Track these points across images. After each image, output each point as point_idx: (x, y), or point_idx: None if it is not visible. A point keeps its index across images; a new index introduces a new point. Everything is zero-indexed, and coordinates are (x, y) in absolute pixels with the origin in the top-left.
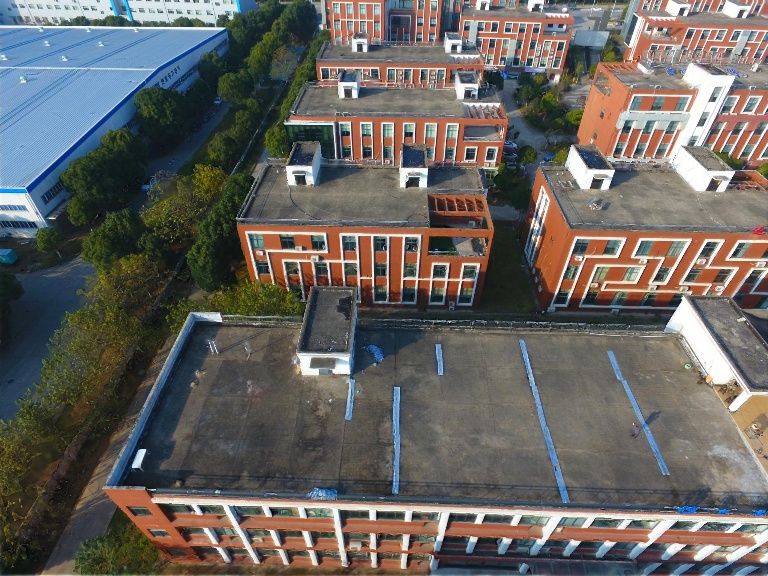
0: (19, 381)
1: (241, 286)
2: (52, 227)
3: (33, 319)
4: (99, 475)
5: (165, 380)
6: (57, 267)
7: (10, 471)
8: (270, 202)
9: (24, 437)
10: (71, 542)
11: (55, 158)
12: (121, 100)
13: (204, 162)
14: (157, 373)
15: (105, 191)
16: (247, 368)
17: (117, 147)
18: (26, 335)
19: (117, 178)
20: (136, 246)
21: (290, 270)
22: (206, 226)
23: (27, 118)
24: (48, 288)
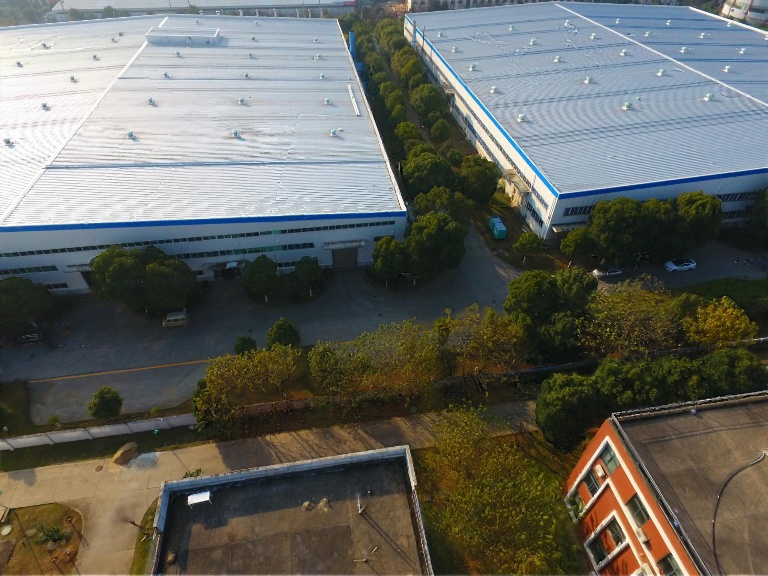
0: (382, 320)
1: (575, 456)
2: (550, 235)
3: (445, 289)
4: (298, 436)
5: (307, 468)
6: (511, 268)
7: (243, 380)
8: (697, 443)
9: (281, 369)
10: (237, 450)
11: (618, 184)
12: (764, 167)
13: (765, 295)
14: (416, 425)
15: (613, 243)
16: (340, 568)
17: (684, 212)
18: (427, 295)
19: (639, 240)
20: (552, 315)
21: (614, 529)
22: (612, 371)
23: (656, 134)
24: (484, 277)
